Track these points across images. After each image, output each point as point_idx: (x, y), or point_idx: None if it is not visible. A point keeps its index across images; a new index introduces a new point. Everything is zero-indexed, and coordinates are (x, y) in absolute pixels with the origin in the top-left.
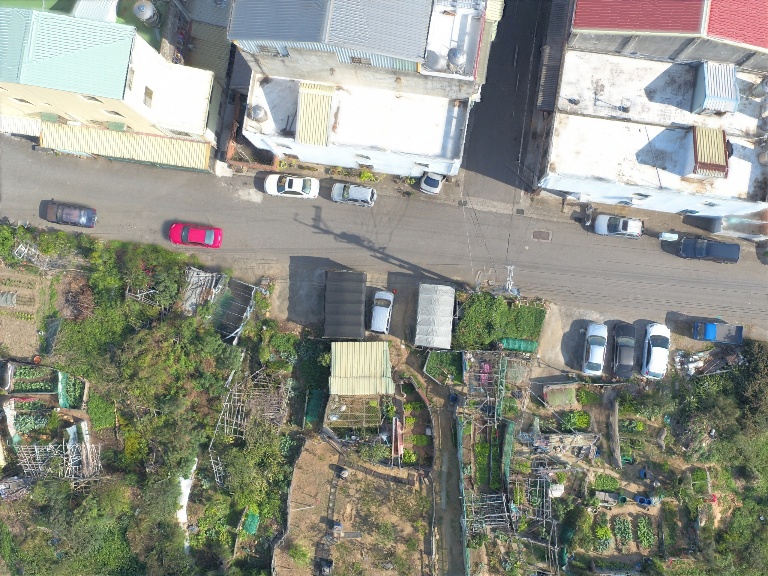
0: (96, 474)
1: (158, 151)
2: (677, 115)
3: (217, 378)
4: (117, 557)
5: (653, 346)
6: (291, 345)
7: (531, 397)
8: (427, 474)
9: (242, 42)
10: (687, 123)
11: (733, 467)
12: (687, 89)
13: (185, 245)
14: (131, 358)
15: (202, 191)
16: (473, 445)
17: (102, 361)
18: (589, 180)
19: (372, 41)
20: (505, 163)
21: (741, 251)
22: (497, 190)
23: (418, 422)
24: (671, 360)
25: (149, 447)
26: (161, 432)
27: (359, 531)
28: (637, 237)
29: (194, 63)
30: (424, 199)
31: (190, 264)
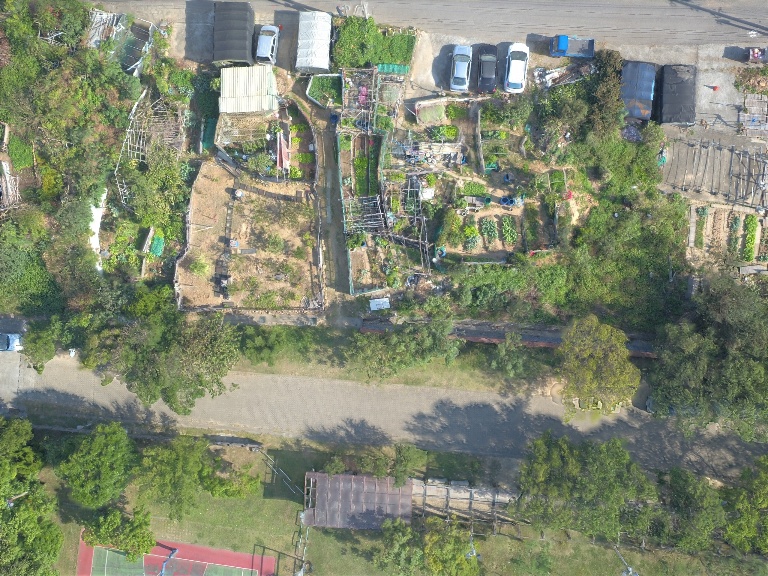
0: (15, 203)
1: None
2: None
3: (121, 111)
4: (37, 282)
5: (512, 59)
6: (188, 80)
7: (405, 116)
8: (313, 190)
9: None
10: None
11: (588, 168)
12: None
13: None
14: (42, 92)
15: None
16: (353, 160)
17: (16, 95)
18: None
19: None
20: None
21: None
22: None
23: (303, 142)
24: (531, 76)
25: (64, 182)
26: (73, 163)
27: (254, 247)
28: None
29: None
30: None
31: None
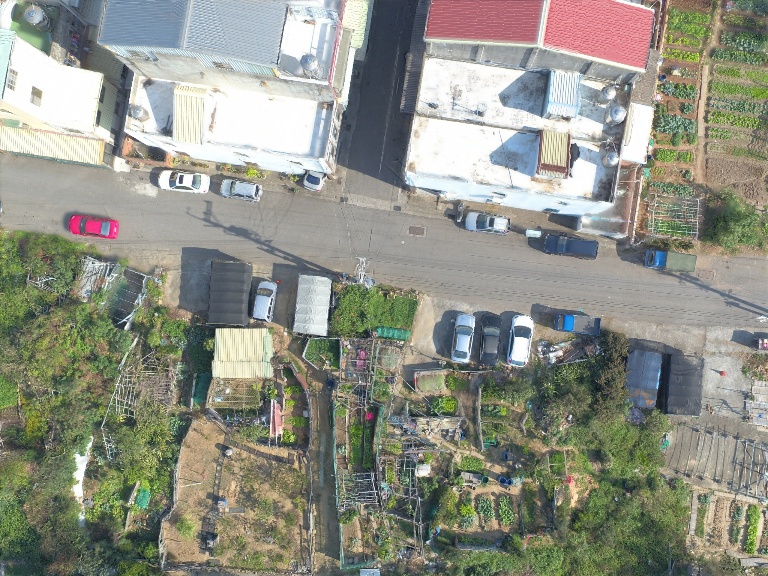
0: None
1: (55, 147)
2: (529, 119)
3: (111, 361)
4: (17, 528)
5: (516, 336)
6: (181, 331)
7: (404, 383)
8: (306, 454)
9: (112, 47)
10: (538, 127)
11: (589, 450)
12: (538, 95)
13: (83, 236)
14: (29, 341)
15: (101, 185)
16: (348, 427)
17: (2, 343)
18: (444, 179)
19: (228, 48)
20: (384, 162)
21: (602, 248)
22: (376, 188)
23: (297, 405)
24: (535, 349)
25: (49, 425)
26: (58, 411)
27: (243, 507)
28: (503, 233)
29: (90, 65)
30: (308, 195)
31: (89, 254)
